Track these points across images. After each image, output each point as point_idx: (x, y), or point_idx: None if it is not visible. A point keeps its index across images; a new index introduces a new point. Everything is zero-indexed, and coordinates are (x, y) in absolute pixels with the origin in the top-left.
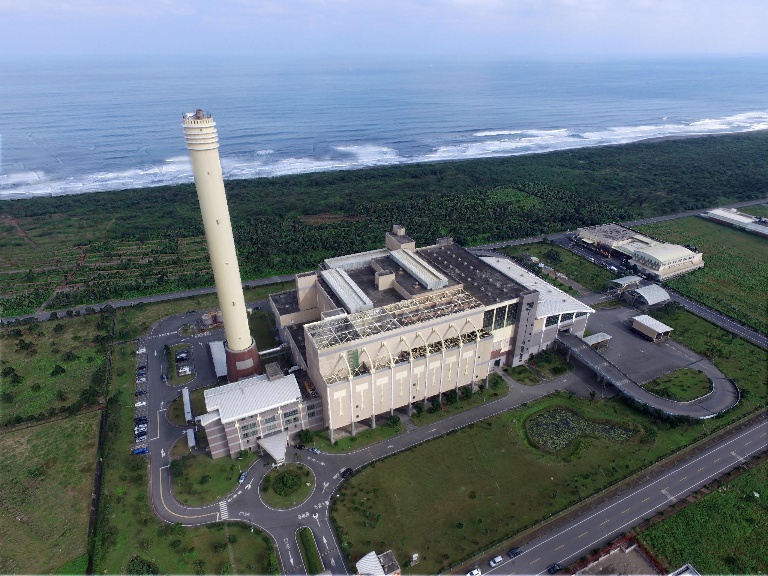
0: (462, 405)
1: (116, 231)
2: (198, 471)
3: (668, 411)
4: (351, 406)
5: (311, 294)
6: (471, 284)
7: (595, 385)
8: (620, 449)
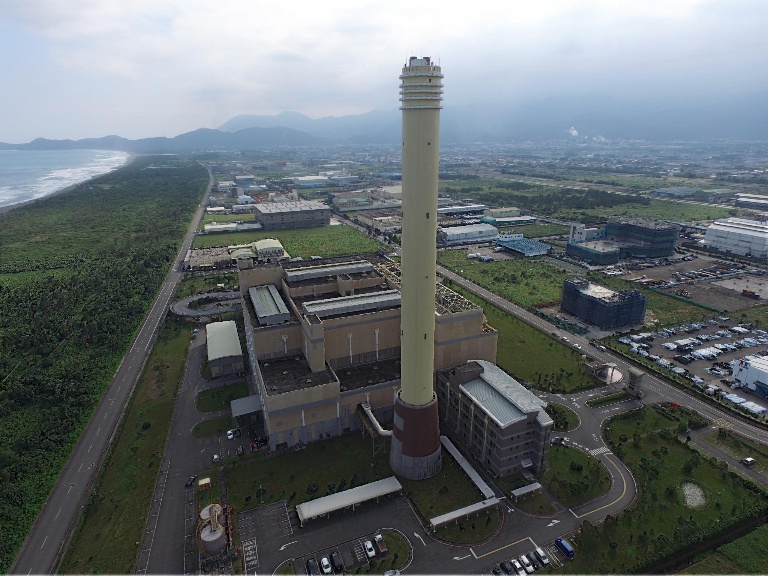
0: None
1: None
2: (566, 479)
3: None
4: None
5: None
6: None
7: None
8: None
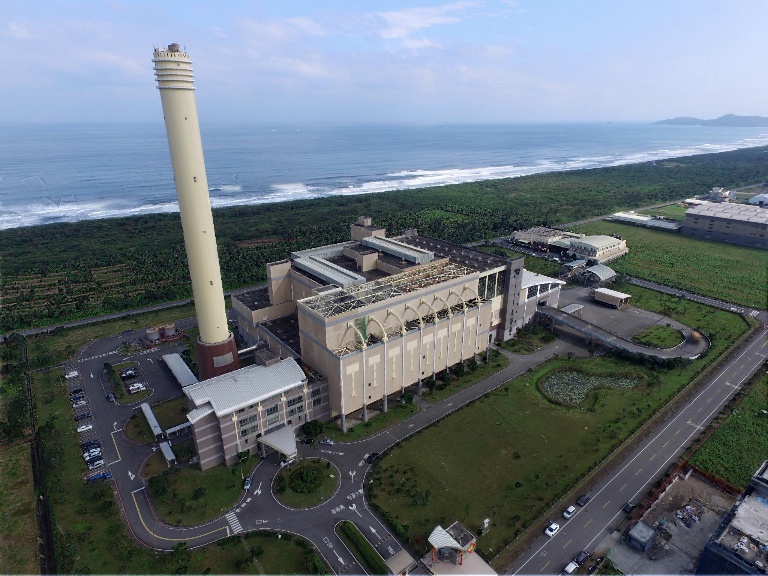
0: (470, 379)
1: (6, 267)
2: (186, 486)
3: (660, 357)
4: (364, 384)
5: (285, 285)
6: (453, 260)
7: (586, 347)
8: (634, 394)
